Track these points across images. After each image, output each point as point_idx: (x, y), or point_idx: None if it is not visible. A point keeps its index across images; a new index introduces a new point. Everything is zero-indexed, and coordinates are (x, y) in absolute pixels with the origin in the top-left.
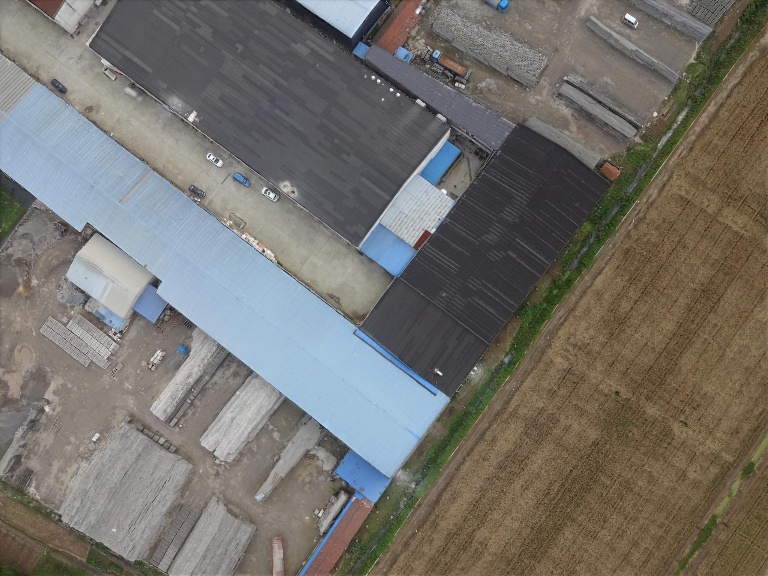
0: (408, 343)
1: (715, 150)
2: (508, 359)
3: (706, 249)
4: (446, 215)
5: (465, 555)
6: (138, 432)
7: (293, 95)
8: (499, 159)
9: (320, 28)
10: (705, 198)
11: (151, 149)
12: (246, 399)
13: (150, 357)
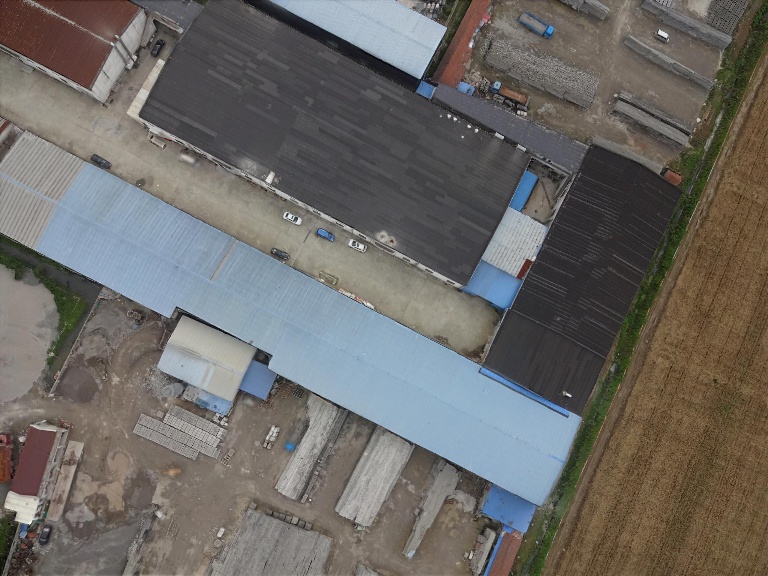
0: (534, 372)
1: (754, 146)
2: (614, 368)
3: (763, 237)
4: (543, 242)
5: (613, 562)
6: (269, 517)
7: (375, 143)
8: (581, 181)
9: (377, 71)
10: (754, 191)
11: (220, 216)
12: (378, 459)
13: (263, 436)
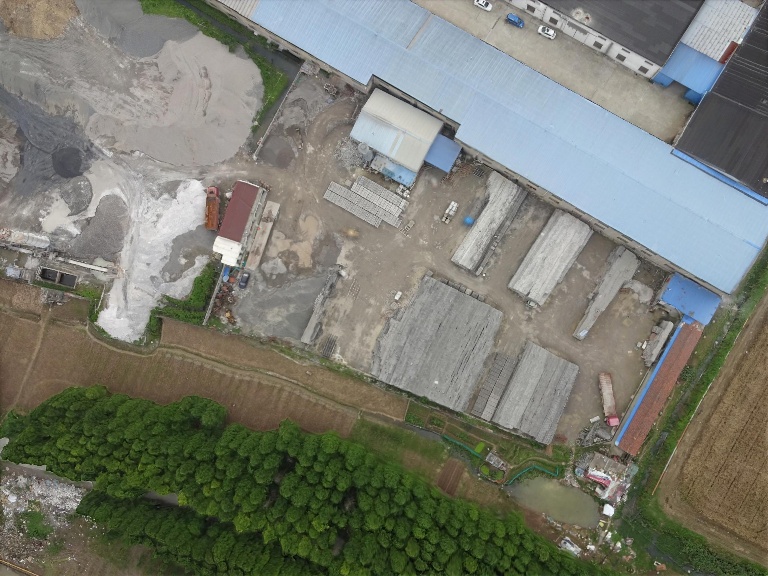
0: (733, 155)
1: None
2: None
3: None
4: (752, 23)
5: None
6: (445, 284)
7: None
8: None
9: None
10: None
11: None
12: (555, 238)
13: (442, 211)
